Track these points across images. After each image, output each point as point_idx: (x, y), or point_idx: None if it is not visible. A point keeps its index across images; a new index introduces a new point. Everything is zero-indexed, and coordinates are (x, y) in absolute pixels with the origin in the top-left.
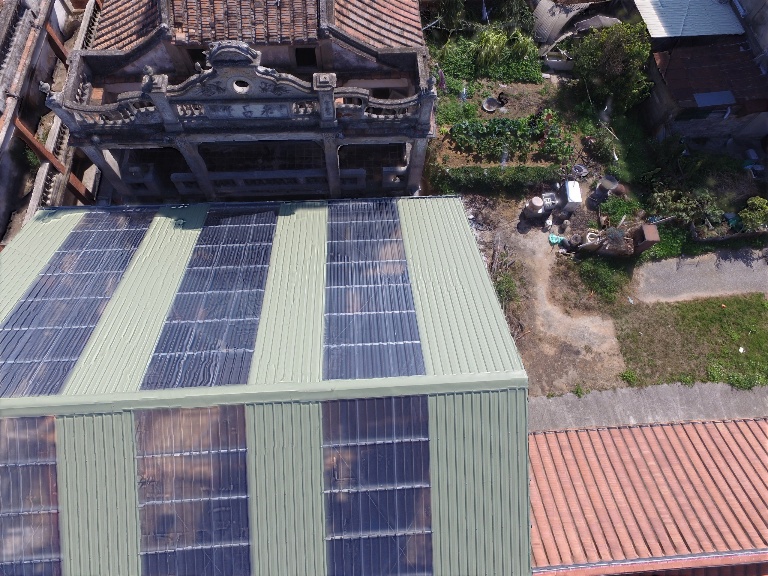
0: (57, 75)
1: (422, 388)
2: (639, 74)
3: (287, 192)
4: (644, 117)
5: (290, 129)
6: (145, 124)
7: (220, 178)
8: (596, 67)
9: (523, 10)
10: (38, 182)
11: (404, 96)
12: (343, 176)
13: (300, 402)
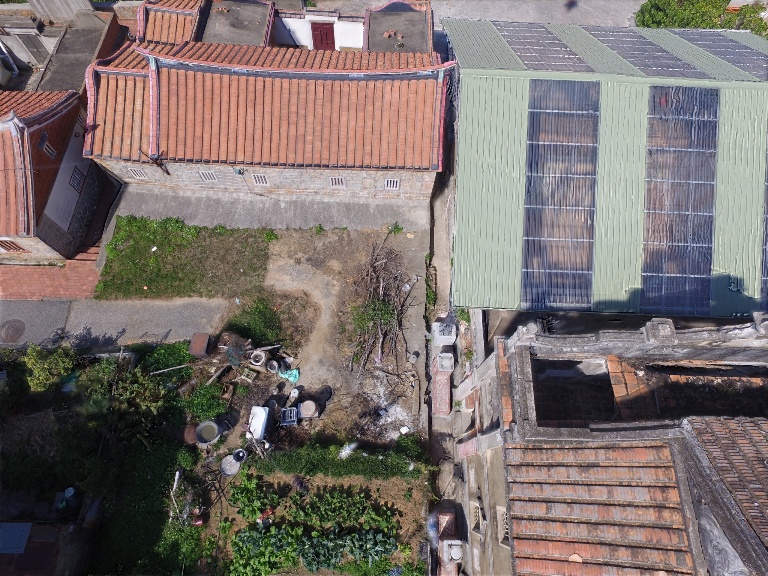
0: None
1: None
2: None
3: None
4: (88, 569)
5: None
6: None
7: None
8: None
9: None
10: None
11: None
12: None
13: None
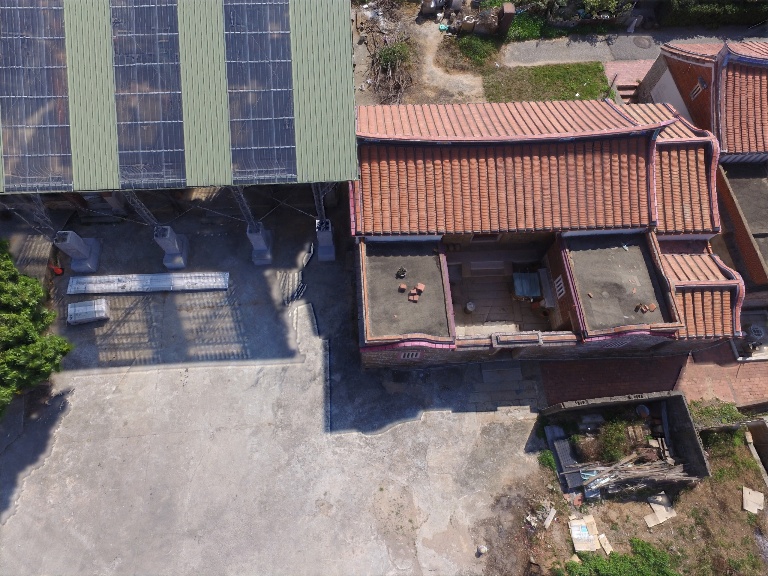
0: None
1: None
2: None
3: None
4: None
5: None
6: None
7: None
8: None
9: None
10: None
11: None
12: None
13: None
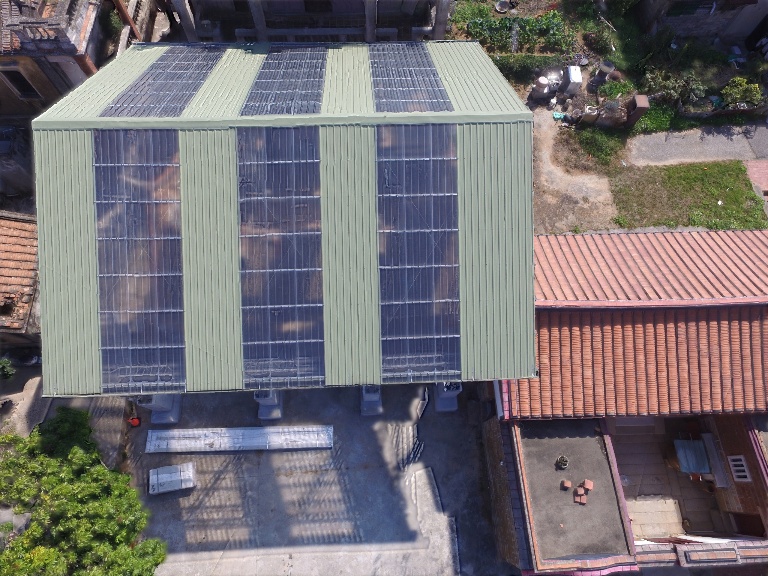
0: None
1: (453, 118)
2: None
3: None
4: (640, 19)
5: None
6: None
7: (276, 33)
8: None
9: None
10: (123, 39)
11: None
12: (379, 34)
13: (361, 126)
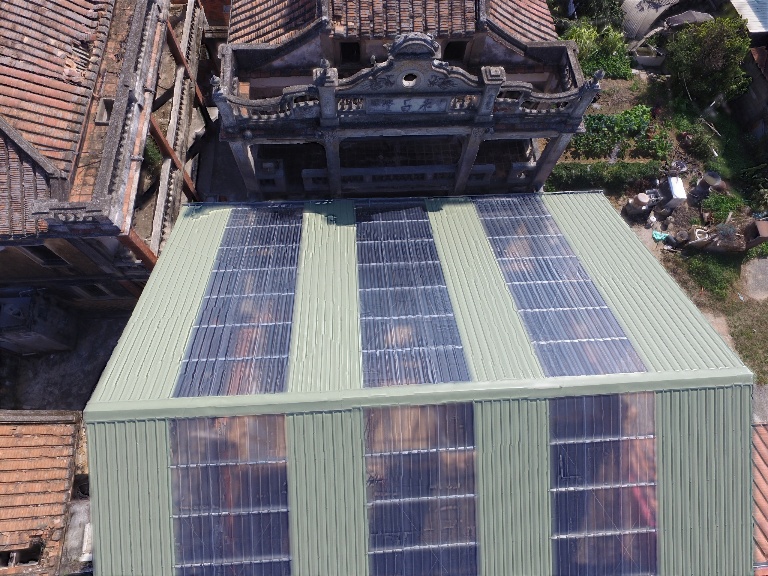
0: (162, 71)
1: (649, 385)
2: (739, 69)
3: (411, 188)
4: (736, 113)
5: (444, 124)
6: (299, 119)
7: (351, 174)
8: (694, 62)
9: (613, 5)
10: (164, 178)
11: (540, 91)
12: (473, 172)
13: (528, 399)
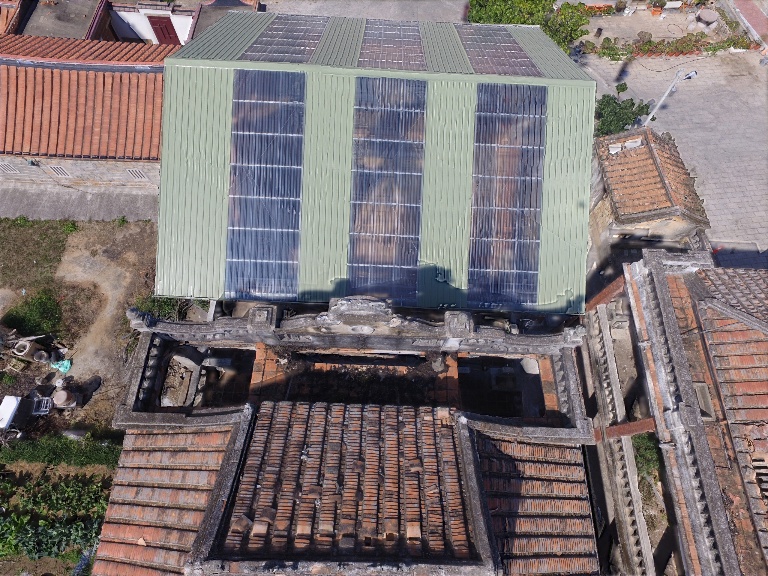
0: None
1: None
2: None
3: None
4: None
5: None
6: None
7: None
8: None
9: None
10: (619, 393)
11: None
12: None
13: None
